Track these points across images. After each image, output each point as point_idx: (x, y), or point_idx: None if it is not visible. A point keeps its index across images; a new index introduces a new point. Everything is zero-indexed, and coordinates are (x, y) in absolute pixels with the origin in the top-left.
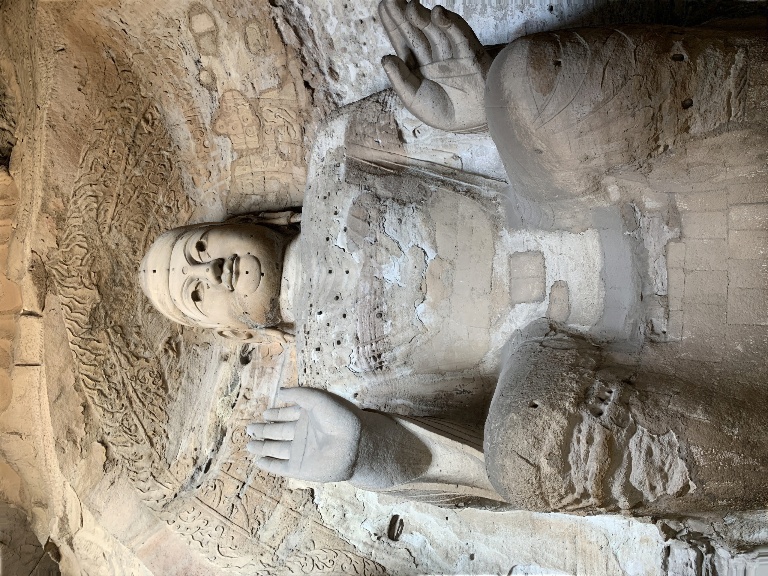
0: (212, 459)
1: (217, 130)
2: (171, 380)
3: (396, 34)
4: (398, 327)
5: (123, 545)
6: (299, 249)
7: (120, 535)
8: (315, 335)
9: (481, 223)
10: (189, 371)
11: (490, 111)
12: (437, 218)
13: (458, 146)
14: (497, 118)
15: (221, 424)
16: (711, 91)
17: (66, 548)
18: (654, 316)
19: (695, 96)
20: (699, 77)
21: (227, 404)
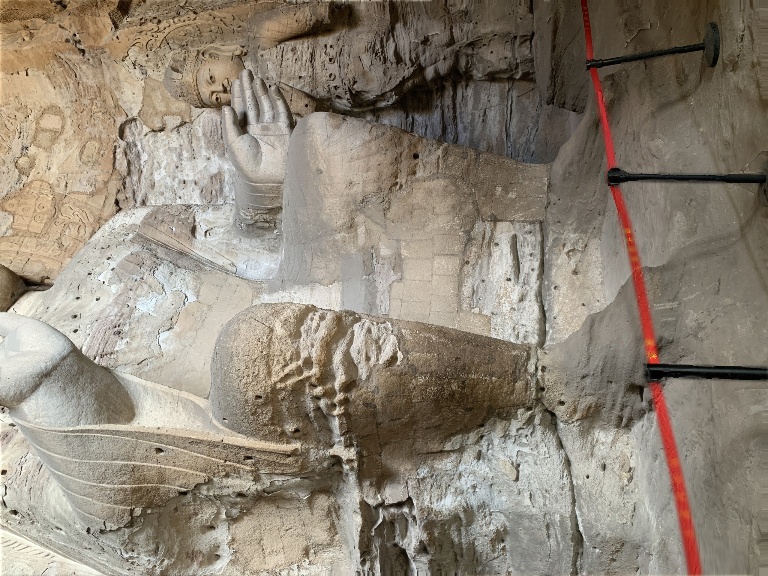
0: None
1: (5, 206)
2: None
3: (238, 101)
4: (133, 346)
5: None
6: (46, 291)
7: None
8: None
9: (245, 289)
10: None
11: (294, 139)
12: (206, 280)
13: (238, 256)
14: (298, 142)
15: None
16: (429, 152)
17: None
18: None
19: (421, 153)
20: (424, 144)
21: None
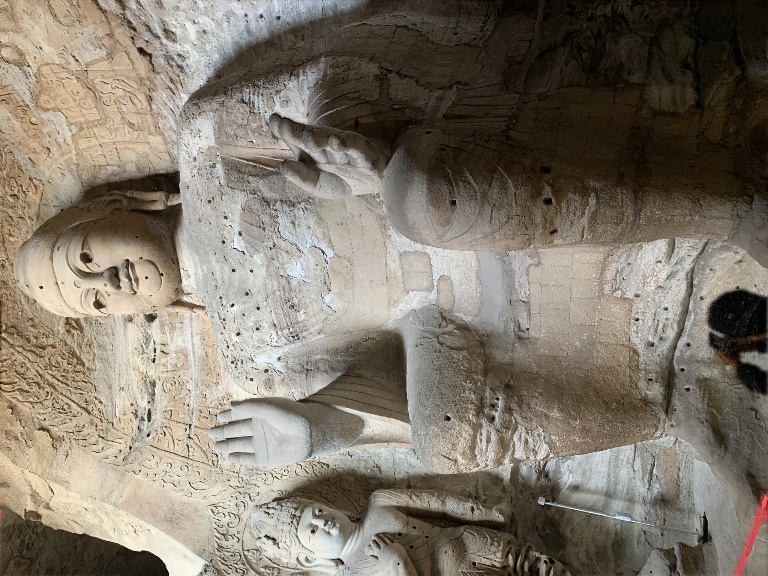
0: (151, 409)
1: (42, 106)
2: (84, 354)
3: None
4: (310, 314)
5: (104, 503)
6: (190, 241)
7: (97, 495)
8: (232, 322)
9: (370, 222)
10: (98, 341)
11: (395, 225)
12: (328, 218)
13: None
14: (402, 231)
15: (148, 379)
16: (571, 226)
17: (44, 510)
18: (520, 317)
19: (559, 228)
20: (563, 217)
21: (147, 361)
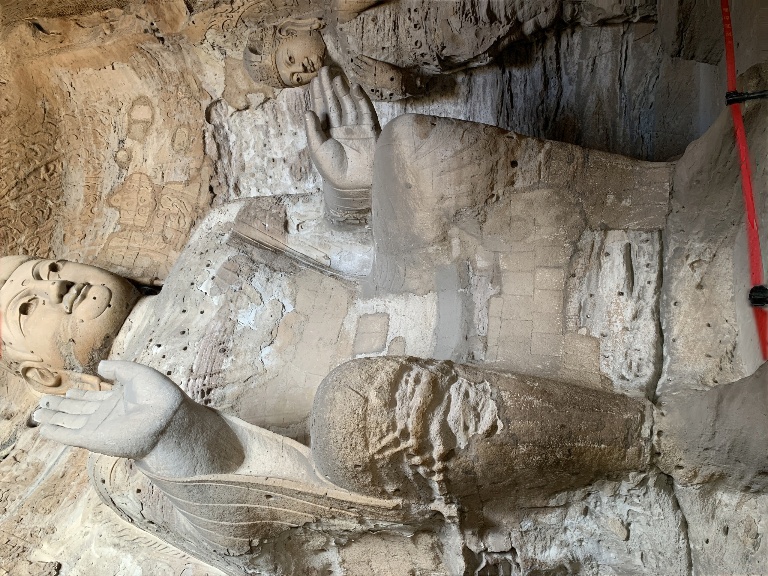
0: None
1: (111, 202)
2: None
3: (319, 102)
4: (238, 364)
5: None
6: (156, 298)
7: None
8: None
9: (339, 293)
10: None
11: (379, 150)
12: (301, 284)
13: (331, 248)
14: (384, 154)
15: None
16: (529, 158)
17: None
18: (475, 349)
19: (519, 160)
20: (523, 149)
21: None
